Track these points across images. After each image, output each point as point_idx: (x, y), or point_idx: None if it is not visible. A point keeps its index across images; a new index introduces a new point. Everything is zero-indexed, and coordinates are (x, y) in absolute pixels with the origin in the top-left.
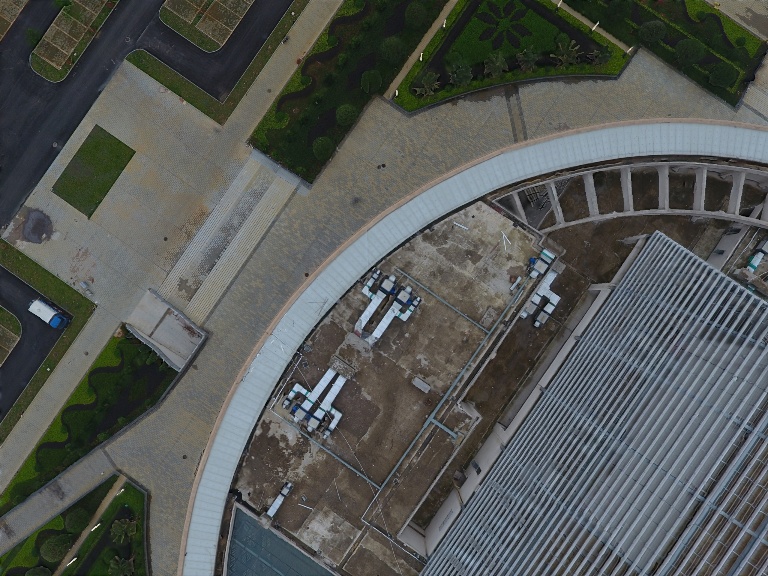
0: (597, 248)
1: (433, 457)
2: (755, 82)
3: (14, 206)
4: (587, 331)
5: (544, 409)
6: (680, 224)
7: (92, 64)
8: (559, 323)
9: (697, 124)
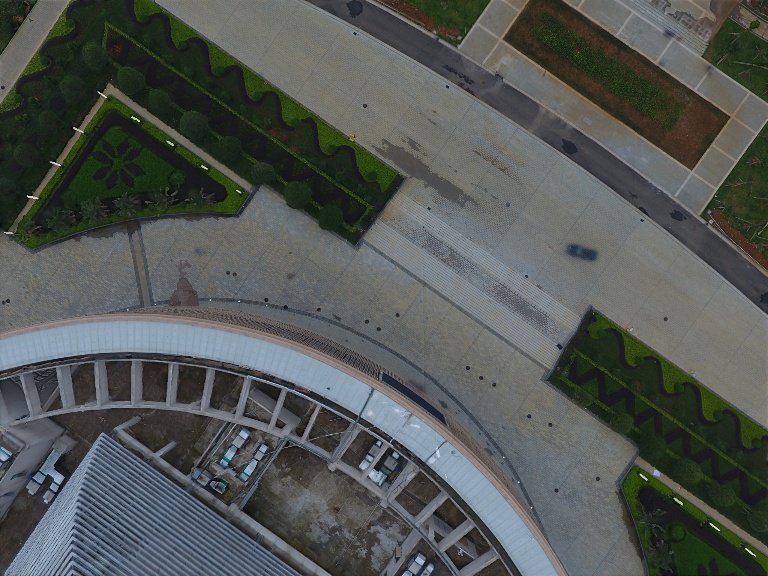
0: (112, 424)
1: None
2: (385, 217)
3: None
4: None
5: None
6: (194, 401)
7: None
8: None
9: (155, 322)
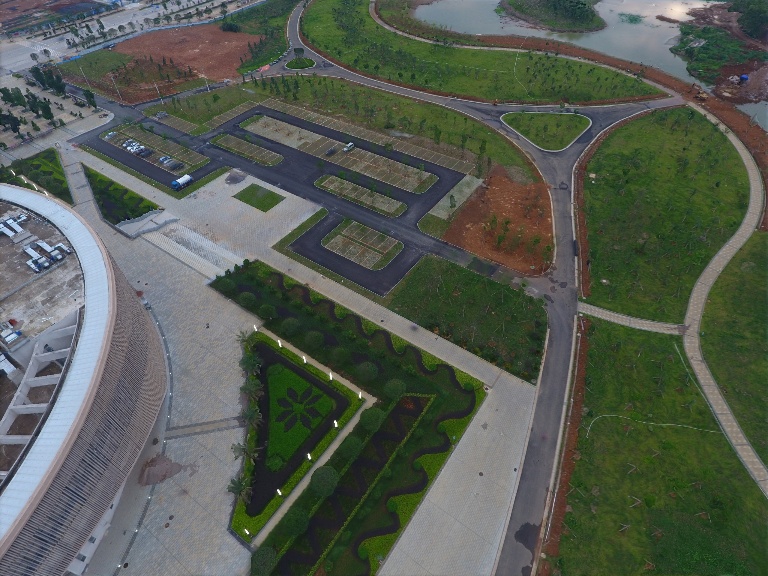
0: None
1: None
2: None
3: (250, 172)
4: None
5: None
6: None
7: (322, 196)
8: None
9: None
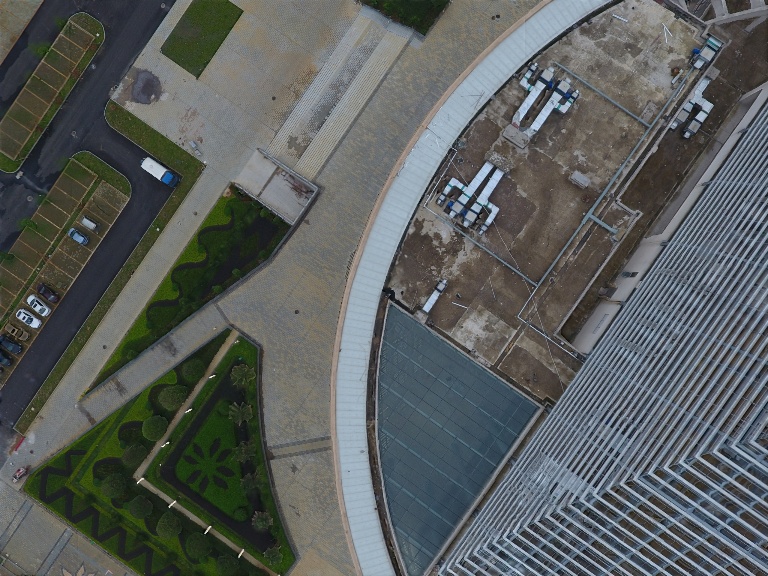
0: (749, 58)
1: (591, 255)
2: None
3: (123, 67)
4: (758, 117)
5: (715, 194)
6: None
7: None
8: (709, 135)
9: None
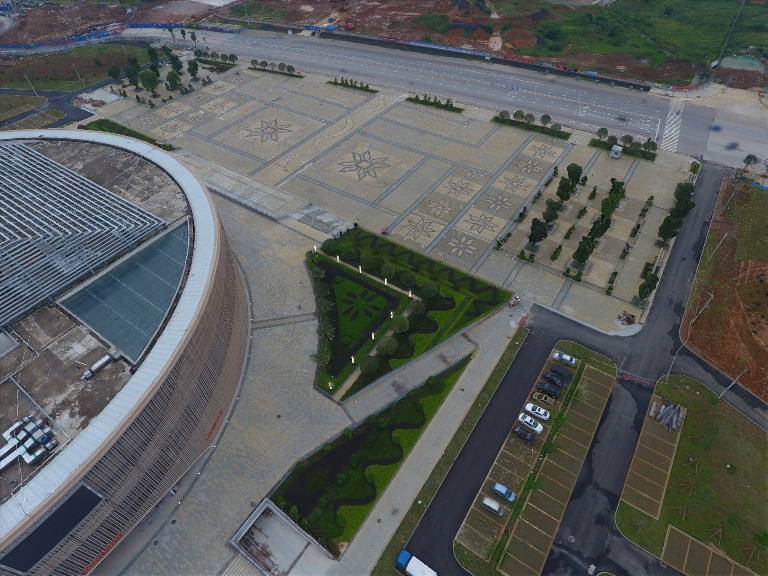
0: None
1: None
2: None
3: None
4: None
5: None
6: None
7: None
8: None
9: None
